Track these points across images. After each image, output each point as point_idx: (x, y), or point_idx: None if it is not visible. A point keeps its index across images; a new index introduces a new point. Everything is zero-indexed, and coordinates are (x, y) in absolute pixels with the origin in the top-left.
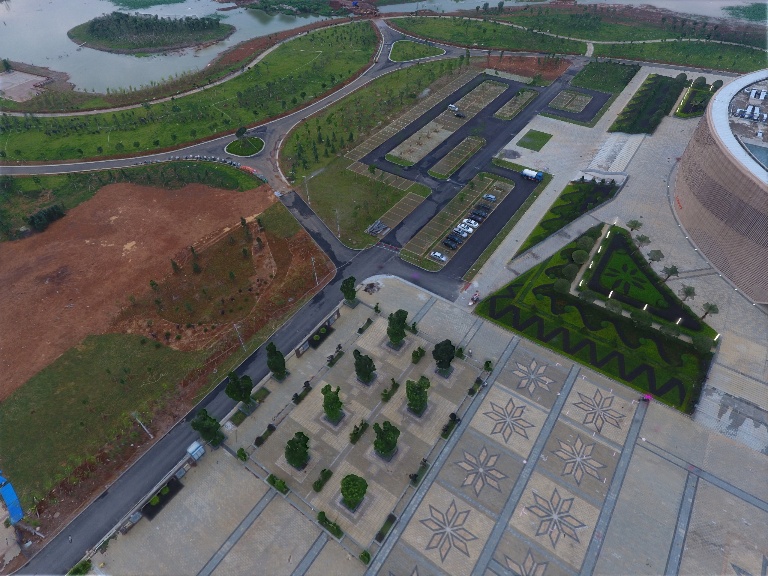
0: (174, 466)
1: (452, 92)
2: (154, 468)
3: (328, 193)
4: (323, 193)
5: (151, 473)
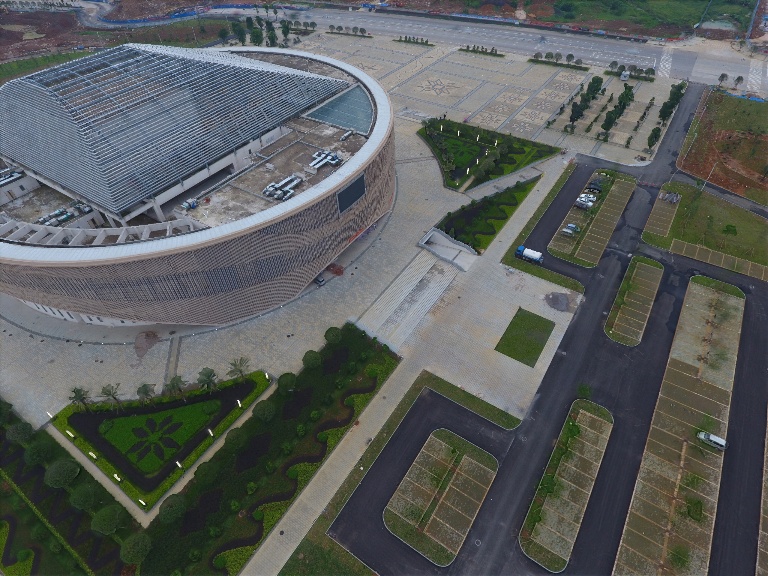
0: (680, 103)
1: (762, 549)
2: (688, 103)
3: (761, 232)
4: (767, 233)
5: (688, 102)
